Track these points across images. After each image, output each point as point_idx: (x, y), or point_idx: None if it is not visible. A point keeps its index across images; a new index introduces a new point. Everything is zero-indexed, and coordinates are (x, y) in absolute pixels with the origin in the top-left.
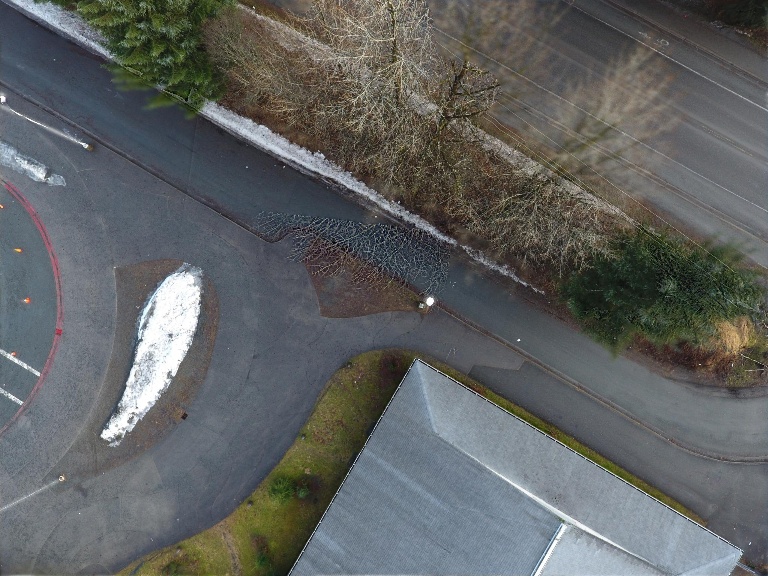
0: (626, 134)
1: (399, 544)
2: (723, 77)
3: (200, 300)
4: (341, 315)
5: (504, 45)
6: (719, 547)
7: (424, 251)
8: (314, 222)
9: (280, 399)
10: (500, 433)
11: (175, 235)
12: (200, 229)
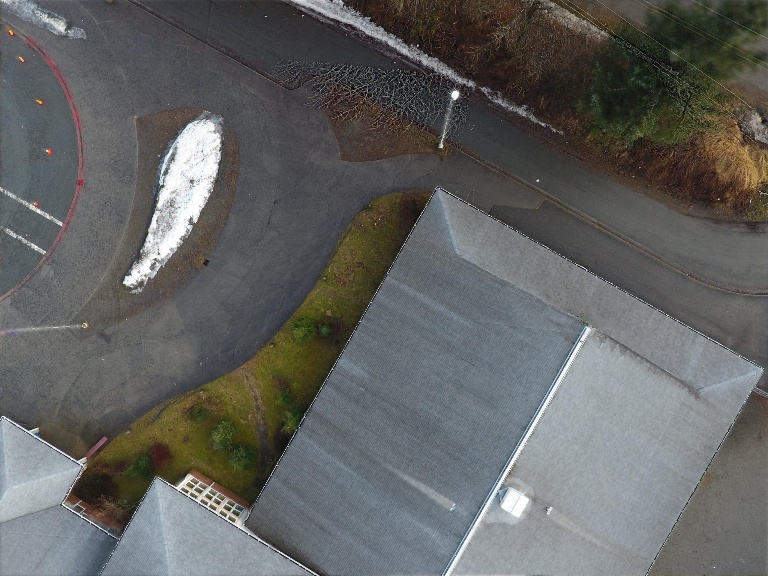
0: None
1: (423, 362)
2: None
3: (221, 147)
4: (361, 159)
5: None
6: (740, 365)
7: (443, 95)
8: (333, 69)
9: (301, 243)
10: (522, 256)
11: (195, 84)
12: (220, 78)
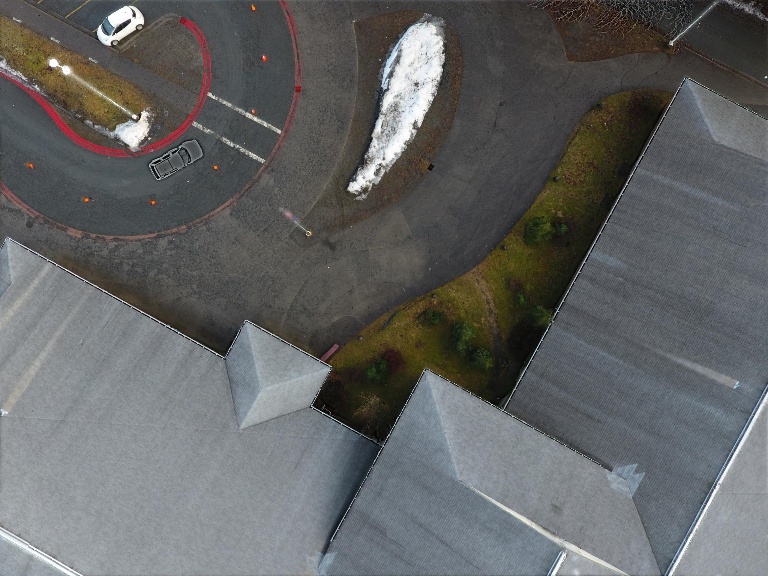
0: None
1: (687, 248)
2: None
3: (444, 49)
4: (587, 59)
5: None
6: None
7: None
8: None
9: (528, 145)
10: None
11: None
12: None
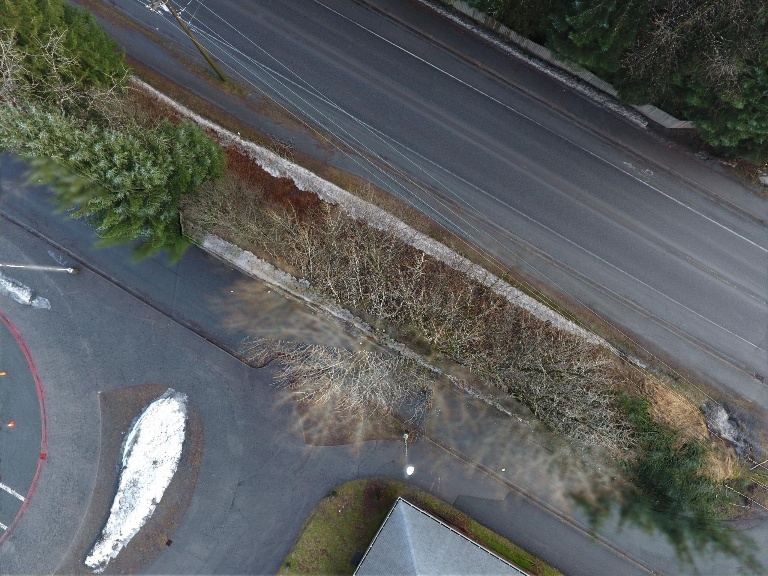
0: (611, 264)
1: None
2: (707, 208)
3: (185, 426)
4: (326, 443)
5: (489, 173)
6: None
7: (409, 378)
8: (299, 348)
9: (265, 527)
10: None
11: (160, 360)
12: (185, 354)
